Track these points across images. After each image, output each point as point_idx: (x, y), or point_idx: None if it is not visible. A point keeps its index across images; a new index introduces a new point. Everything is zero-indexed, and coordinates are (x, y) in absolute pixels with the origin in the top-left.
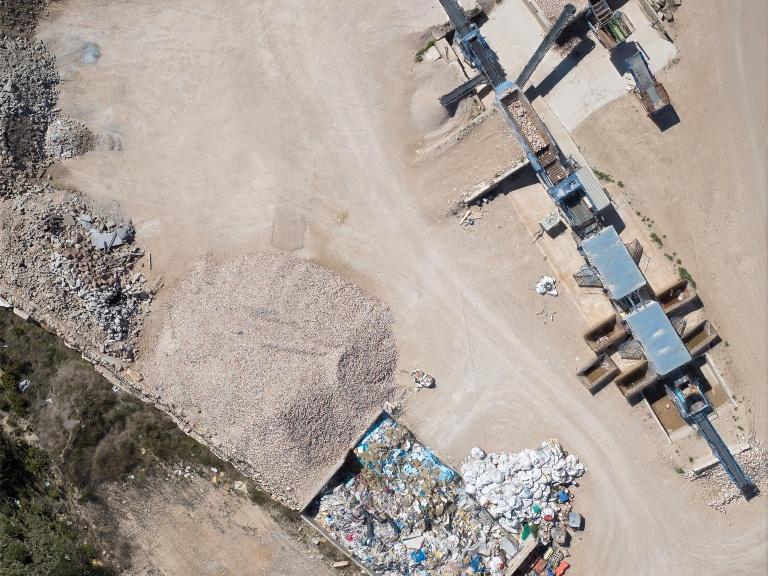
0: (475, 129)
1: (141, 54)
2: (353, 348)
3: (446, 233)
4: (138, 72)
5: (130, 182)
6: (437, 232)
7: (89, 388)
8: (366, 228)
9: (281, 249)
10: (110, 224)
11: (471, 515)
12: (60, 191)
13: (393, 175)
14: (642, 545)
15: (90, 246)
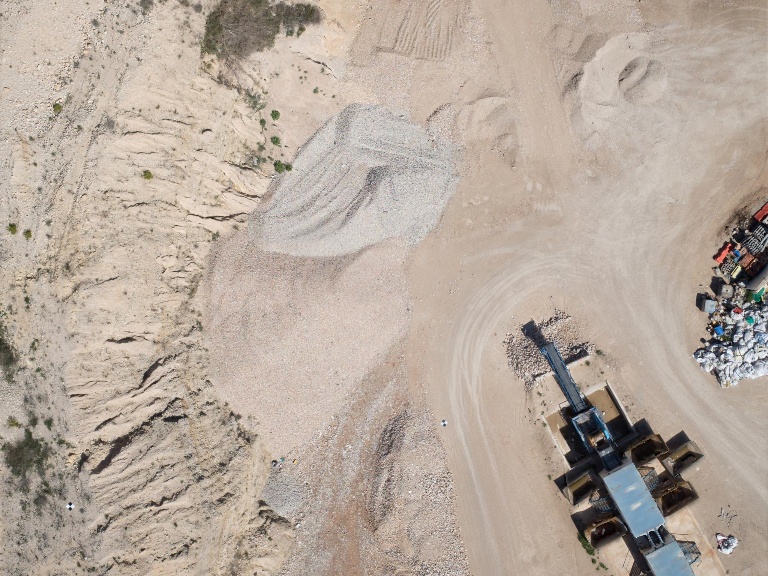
0: None
1: None
2: None
3: None
4: None
5: None
6: None
7: None
8: None
9: None
10: None
11: None
12: None
13: None
14: (639, 278)
15: None
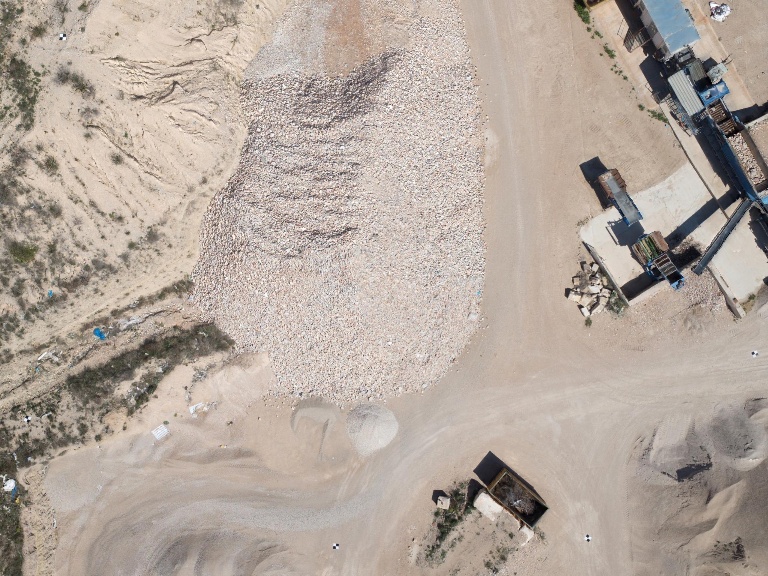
0: None
1: None
2: None
3: None
4: None
5: None
6: None
7: None
8: None
9: None
10: None
11: None
12: None
13: None
14: None
15: None
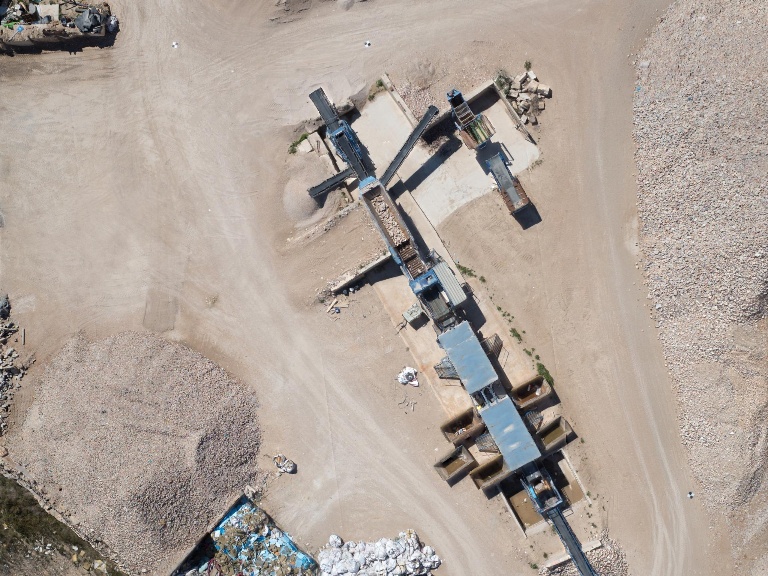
0: (341, 221)
1: (27, 135)
2: (214, 431)
3: (313, 320)
4: (23, 152)
5: (9, 258)
6: (304, 319)
7: None
8: (236, 312)
9: (152, 330)
10: None
11: None
12: None
13: (264, 262)
14: None
15: None
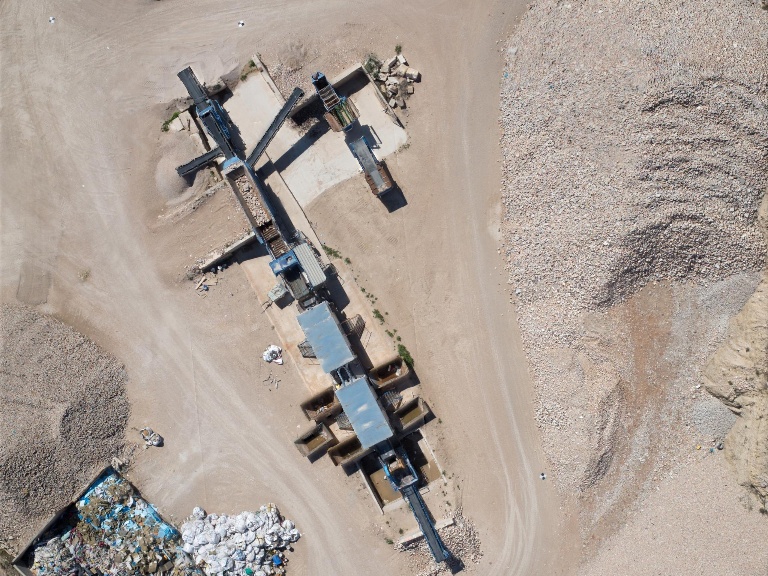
0: (209, 200)
1: None
2: (80, 404)
3: (182, 297)
4: None
5: None
6: (174, 295)
7: None
8: (107, 287)
9: (26, 303)
10: None
11: (185, 574)
12: None
13: (135, 238)
14: None
15: None
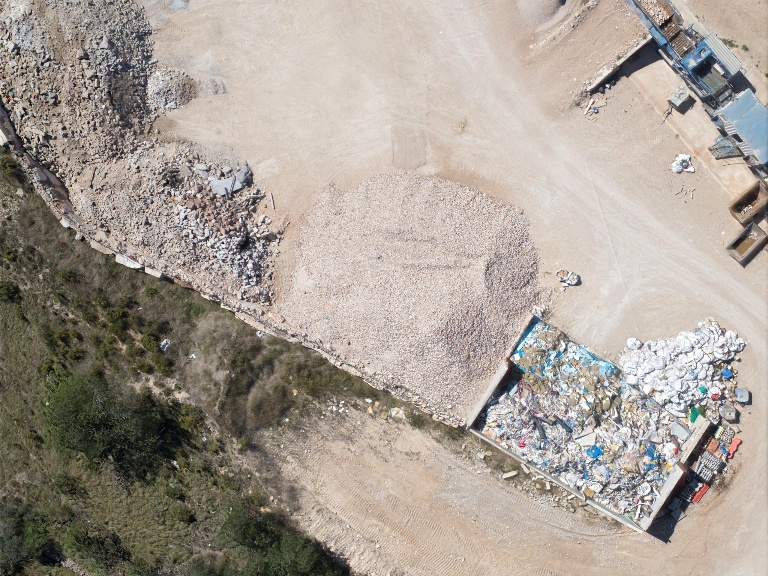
0: (590, 13)
1: None
2: (496, 256)
3: (571, 126)
4: (231, 10)
5: (240, 124)
6: (562, 126)
7: (233, 337)
8: (488, 134)
9: (404, 168)
10: (226, 169)
11: (638, 405)
12: (170, 144)
13: (509, 75)
14: None
15: (211, 194)
